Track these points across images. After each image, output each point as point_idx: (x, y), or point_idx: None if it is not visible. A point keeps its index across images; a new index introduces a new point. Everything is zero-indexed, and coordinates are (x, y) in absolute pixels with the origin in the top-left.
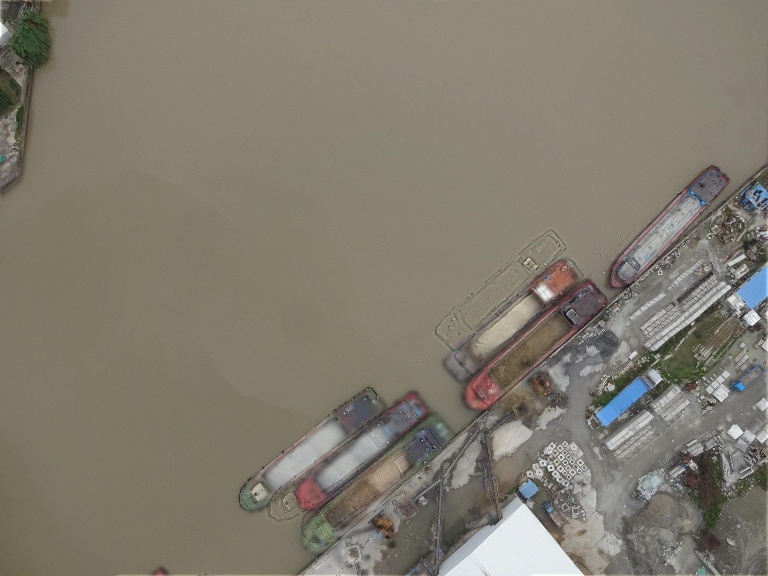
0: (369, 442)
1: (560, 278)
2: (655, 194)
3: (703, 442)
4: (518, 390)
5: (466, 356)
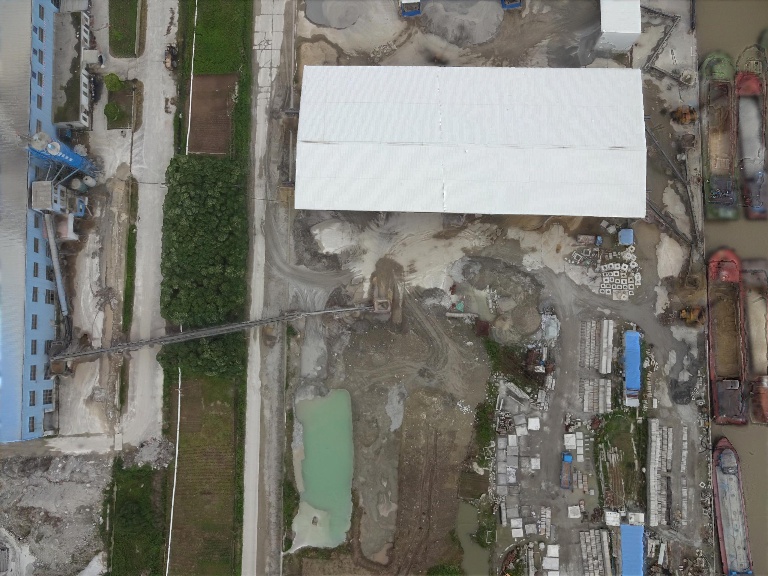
0: (747, 157)
1: (766, 403)
2: (766, 545)
3: (547, 393)
4: (701, 295)
5: (759, 280)
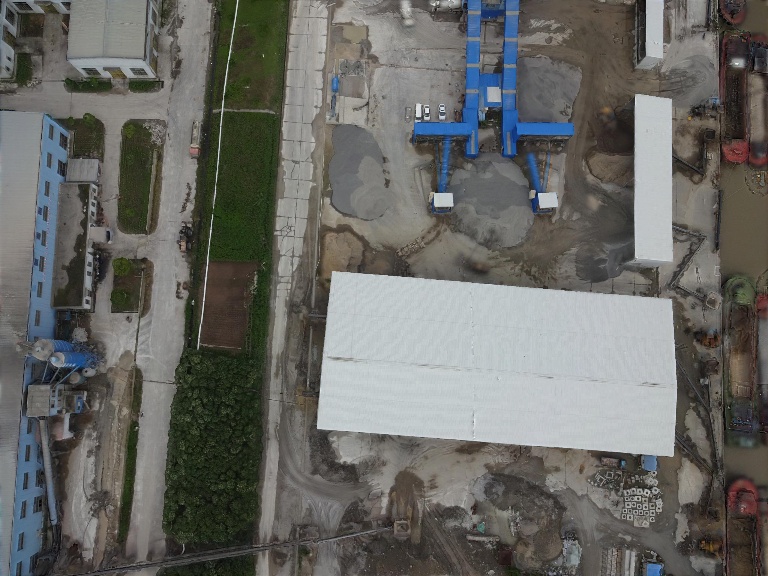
0: (765, 380)
1: None
2: None
3: None
4: (720, 524)
5: None
